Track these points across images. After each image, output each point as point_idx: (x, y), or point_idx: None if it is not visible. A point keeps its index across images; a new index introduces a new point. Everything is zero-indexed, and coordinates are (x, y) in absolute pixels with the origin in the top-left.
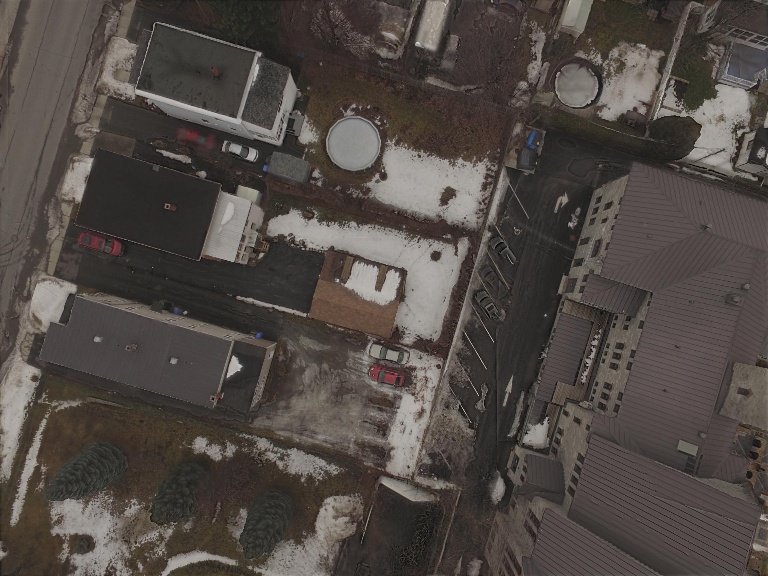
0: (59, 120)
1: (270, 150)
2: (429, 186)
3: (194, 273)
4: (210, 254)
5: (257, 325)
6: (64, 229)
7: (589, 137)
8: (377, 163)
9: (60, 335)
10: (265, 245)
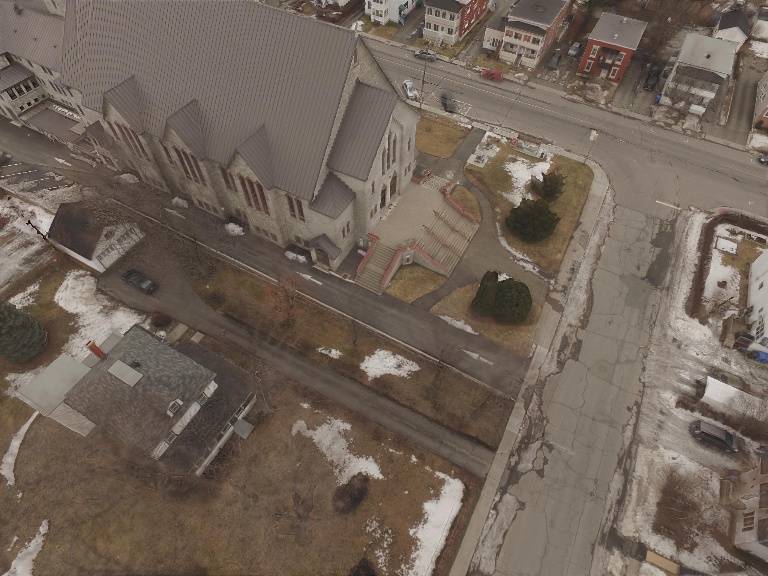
0: None
1: None
2: None
3: None
4: None
5: None
6: None
7: None
8: None
9: None
10: None
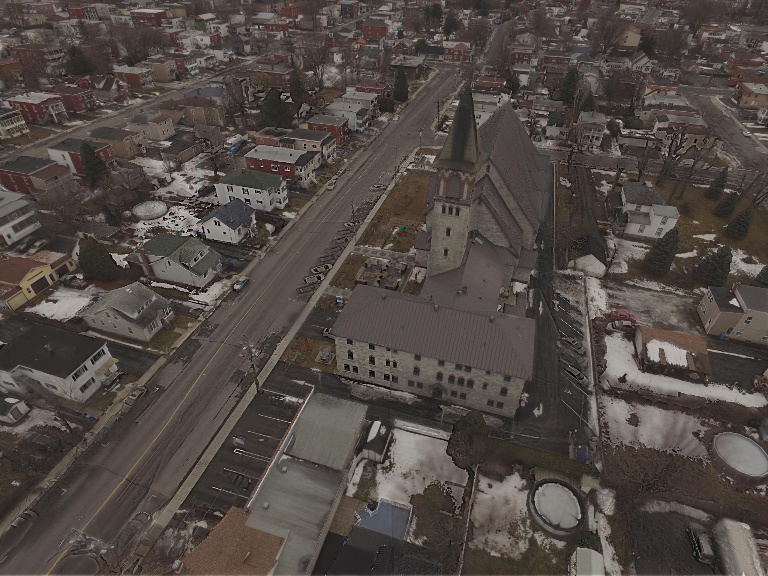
0: None
1: None
2: (653, 427)
3: None
4: None
5: (727, 343)
6: None
7: None
8: (708, 445)
9: None
10: None
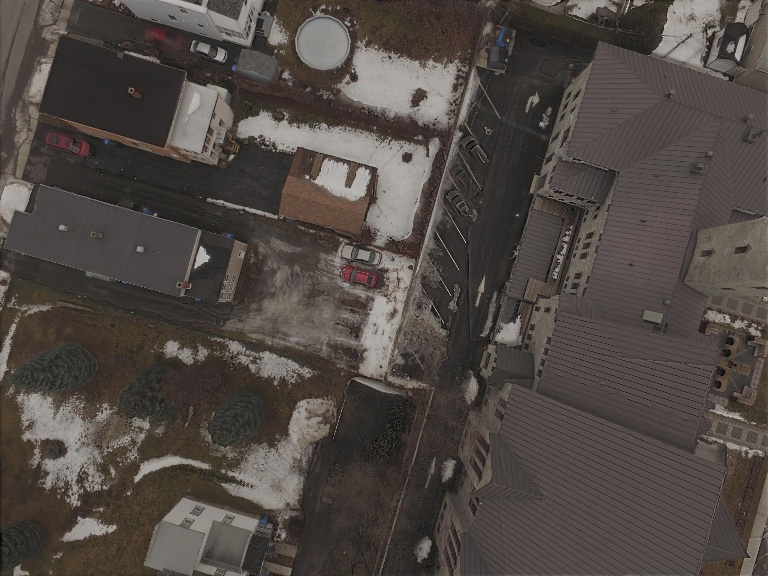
0: (26, 22)
1: (239, 51)
2: (400, 87)
3: (164, 175)
4: (176, 144)
5: (228, 227)
6: (32, 132)
7: (559, 35)
8: (347, 64)
9: (25, 224)
10: (235, 146)
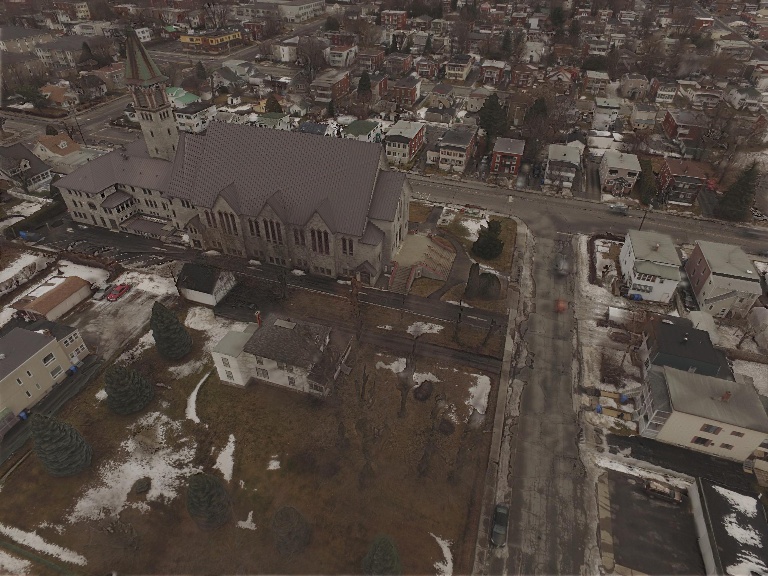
0: None
1: None
2: None
3: None
4: None
5: None
6: None
7: (42, 219)
8: None
9: None
10: None
